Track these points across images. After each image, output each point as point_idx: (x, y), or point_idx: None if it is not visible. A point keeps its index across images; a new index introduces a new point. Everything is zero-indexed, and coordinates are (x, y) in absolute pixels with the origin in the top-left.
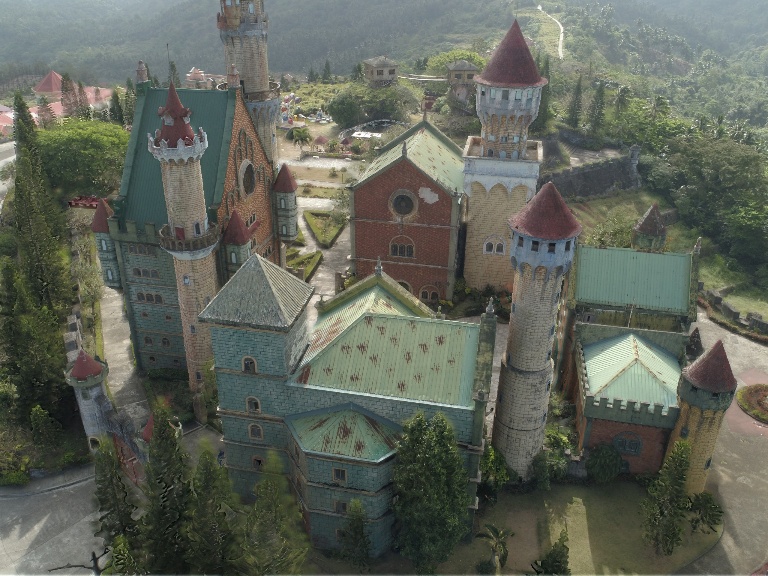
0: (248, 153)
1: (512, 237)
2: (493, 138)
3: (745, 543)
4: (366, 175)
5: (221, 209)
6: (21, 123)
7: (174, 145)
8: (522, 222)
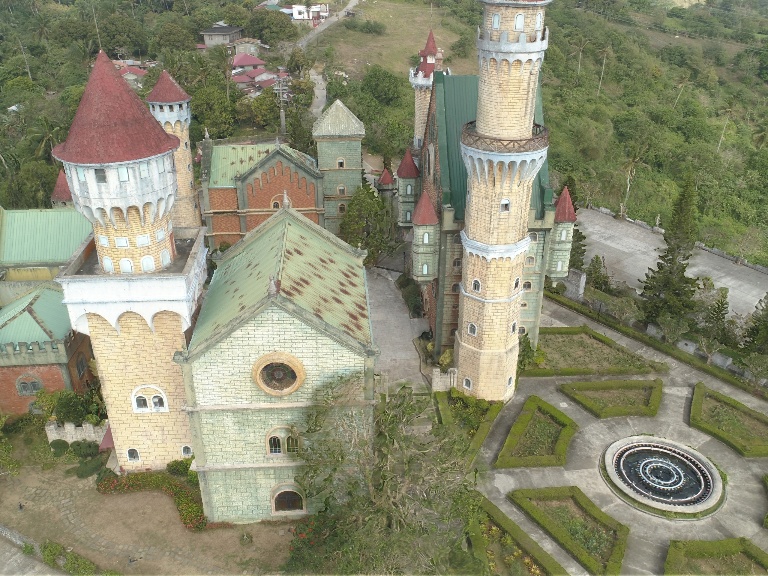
0: None
1: None
2: None
3: None
4: (361, 295)
5: None
6: None
7: None
8: None
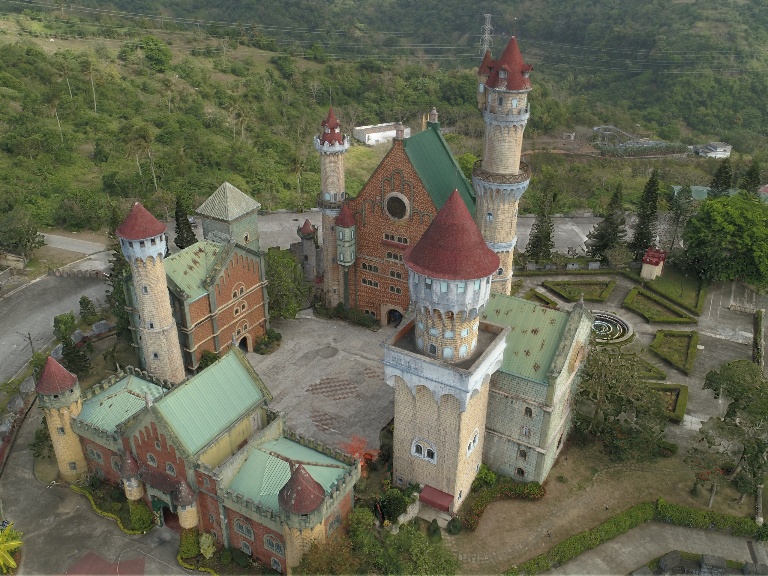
0: (407, 192)
1: None
2: None
3: (19, 482)
4: None
5: (357, 203)
6: (656, 169)
7: None
8: None
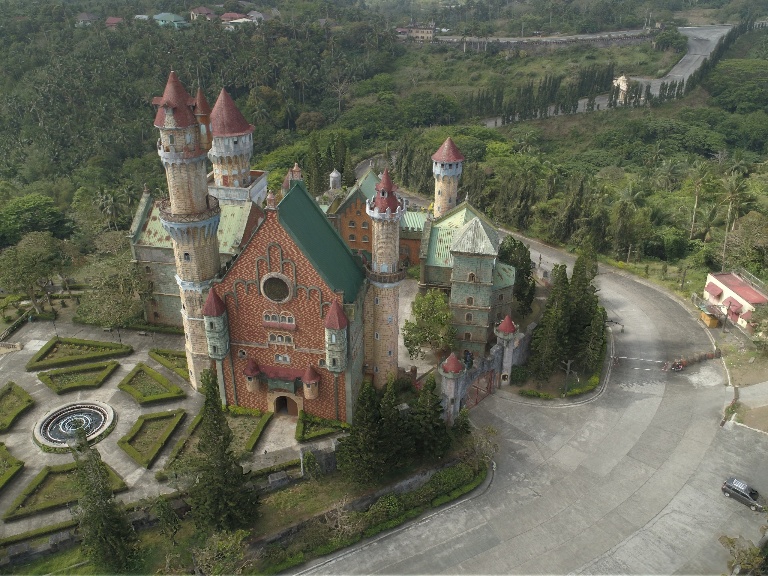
0: None
1: (449, 168)
2: (244, 170)
3: None
4: None
5: None
6: None
7: (400, 205)
8: (455, 158)
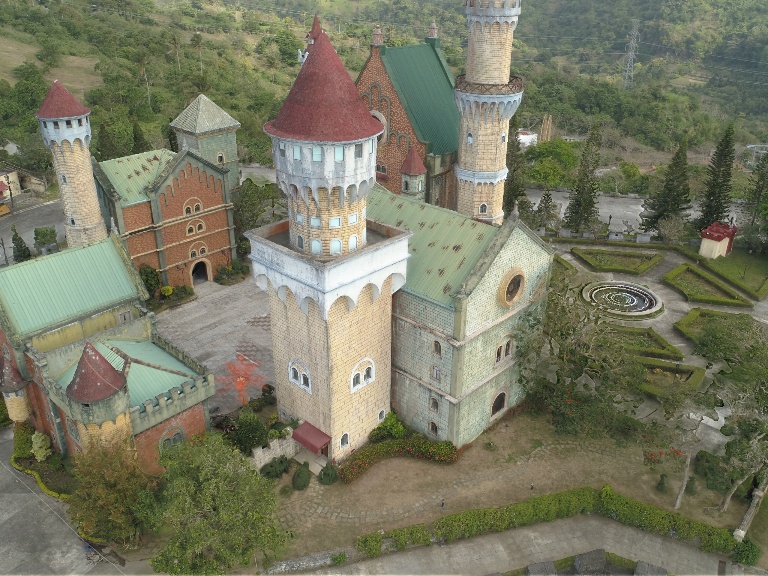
0: None
1: None
2: None
3: None
4: None
5: None
6: None
7: None
8: None
